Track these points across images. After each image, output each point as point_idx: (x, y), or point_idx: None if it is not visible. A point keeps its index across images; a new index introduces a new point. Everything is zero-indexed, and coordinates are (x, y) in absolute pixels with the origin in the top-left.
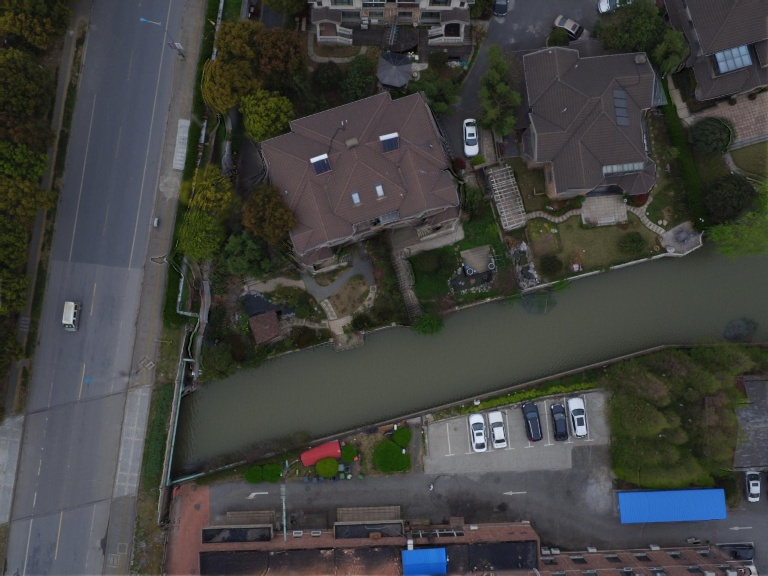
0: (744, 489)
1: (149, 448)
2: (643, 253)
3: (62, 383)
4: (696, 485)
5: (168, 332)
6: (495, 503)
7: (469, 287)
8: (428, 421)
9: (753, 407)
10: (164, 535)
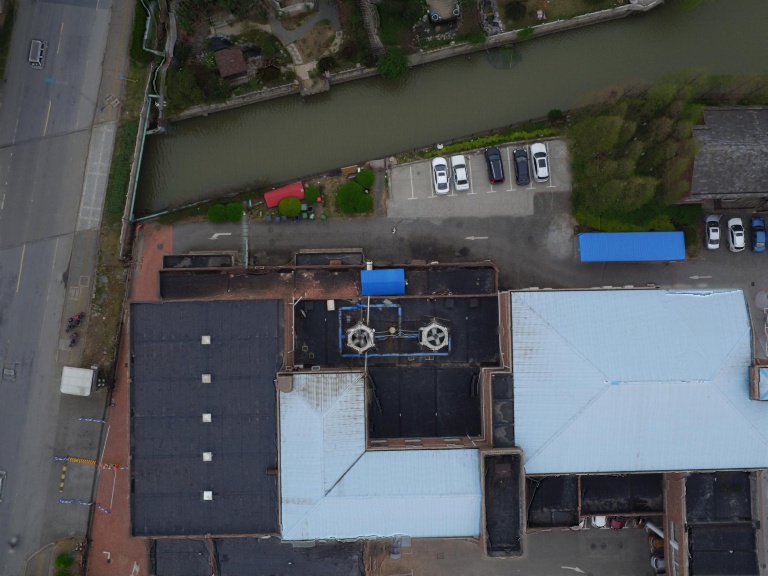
0: (704, 237)
1: (113, 182)
2: (606, 3)
3: (27, 119)
4: (656, 230)
5: (134, 71)
6: (457, 247)
7: (434, 34)
8: (391, 164)
9: (710, 132)
10: (126, 272)
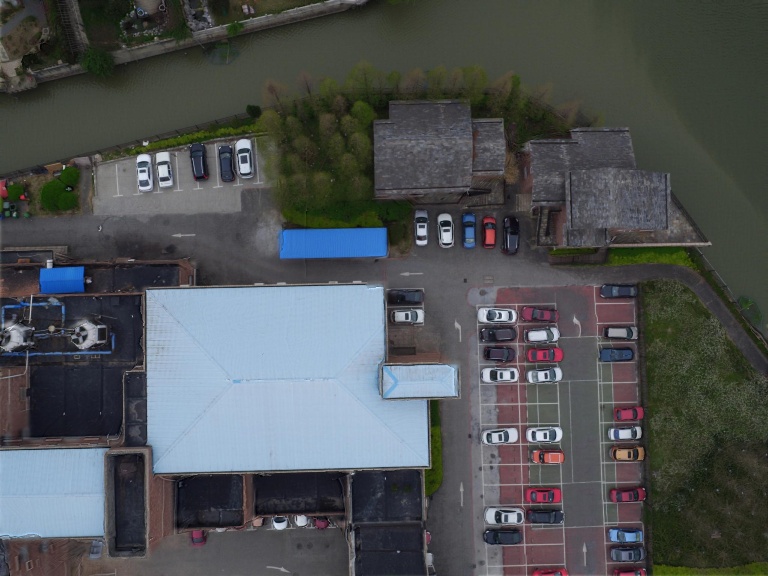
0: (413, 233)
1: None
2: None
3: None
4: (362, 226)
5: None
6: (164, 245)
7: (142, 30)
8: (96, 161)
9: (392, 127)
10: None
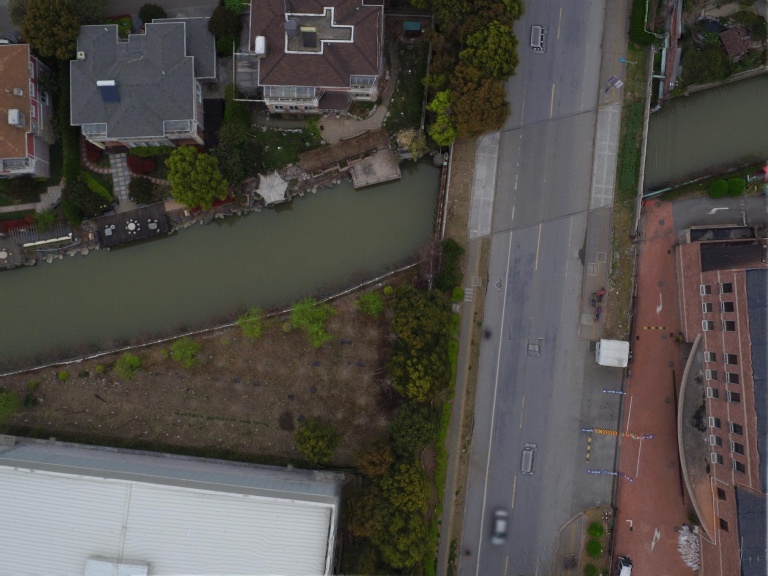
0: None
1: (624, 161)
2: None
3: (534, 102)
4: None
5: (633, 53)
6: None
7: None
8: None
9: None
10: (634, 248)
